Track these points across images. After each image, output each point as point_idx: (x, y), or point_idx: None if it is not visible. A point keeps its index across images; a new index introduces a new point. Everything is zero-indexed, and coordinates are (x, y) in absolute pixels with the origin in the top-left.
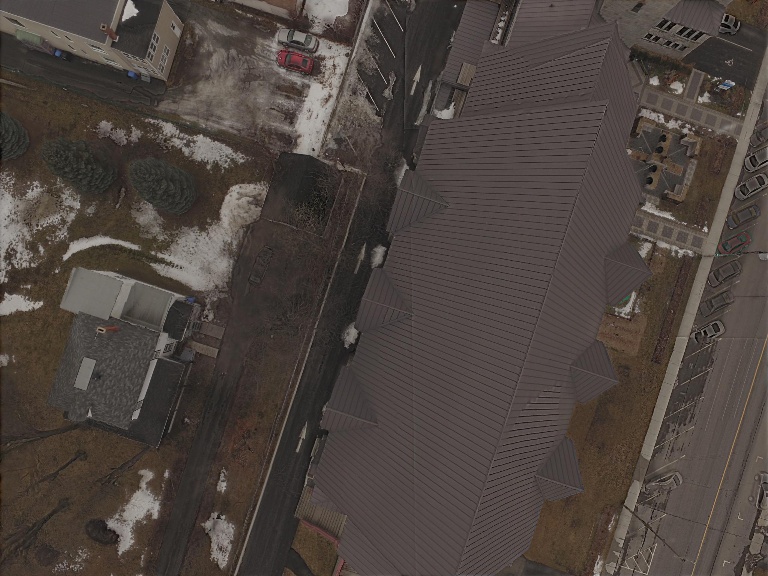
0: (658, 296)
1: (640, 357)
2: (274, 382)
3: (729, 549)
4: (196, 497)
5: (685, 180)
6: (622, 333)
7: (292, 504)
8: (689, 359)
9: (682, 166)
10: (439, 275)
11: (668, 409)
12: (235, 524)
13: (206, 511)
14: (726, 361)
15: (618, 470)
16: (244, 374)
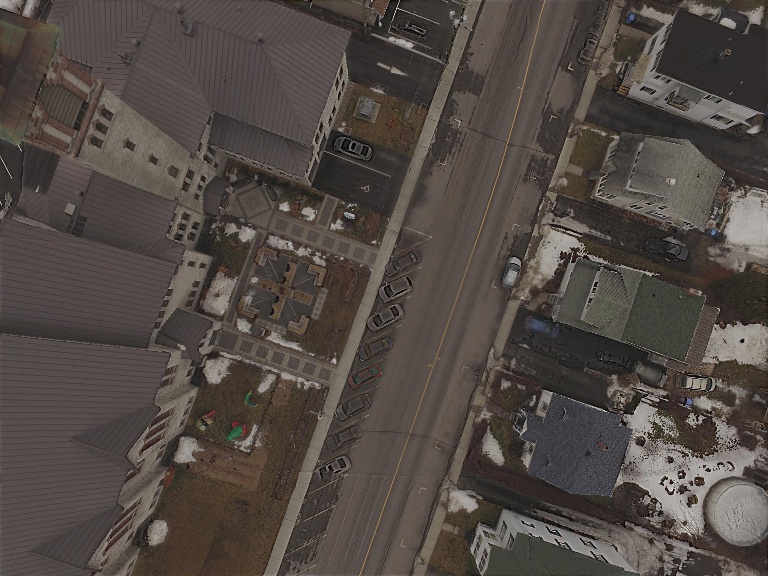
0: (281, 429)
1: (260, 492)
2: None
3: None
4: None
5: (314, 310)
6: (240, 467)
7: None
8: (313, 495)
9: (312, 295)
10: None
11: (289, 546)
12: None
13: None
14: (351, 498)
15: None
16: None
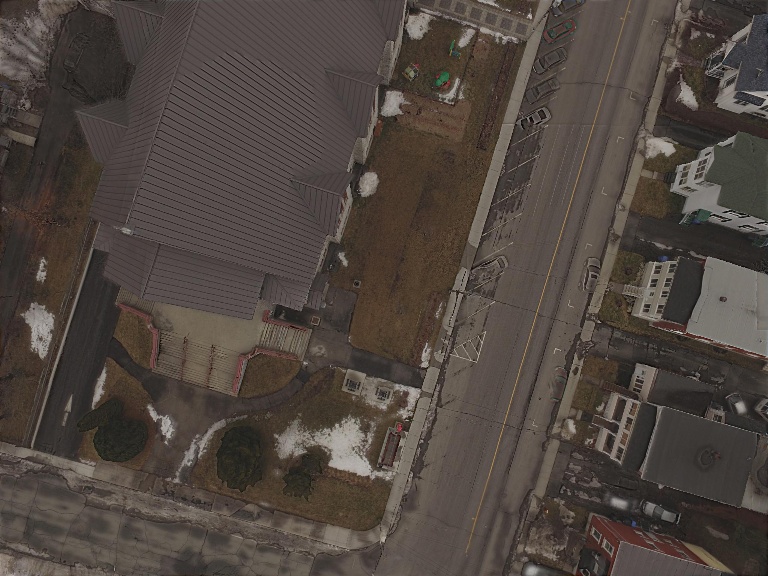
0: (482, 83)
1: (465, 143)
2: (94, 171)
3: (560, 336)
4: (15, 287)
5: None
6: (446, 119)
7: (113, 293)
8: (516, 146)
9: None
10: None
11: (495, 196)
12: (55, 314)
13: (26, 301)
14: (553, 148)
15: (445, 257)
16: (63, 163)
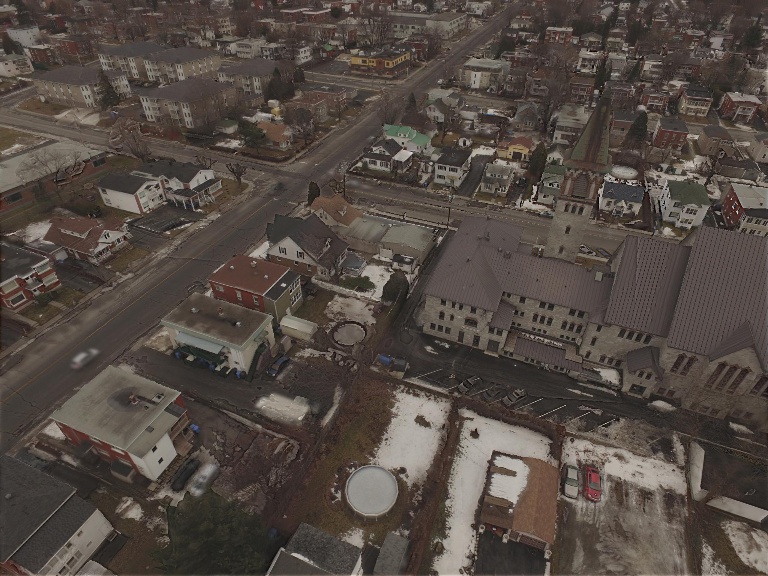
0: None
1: None
2: None
3: None
4: None
5: None
6: None
7: None
8: None
9: None
10: None
11: None
12: None
13: None
14: None
15: None
16: None
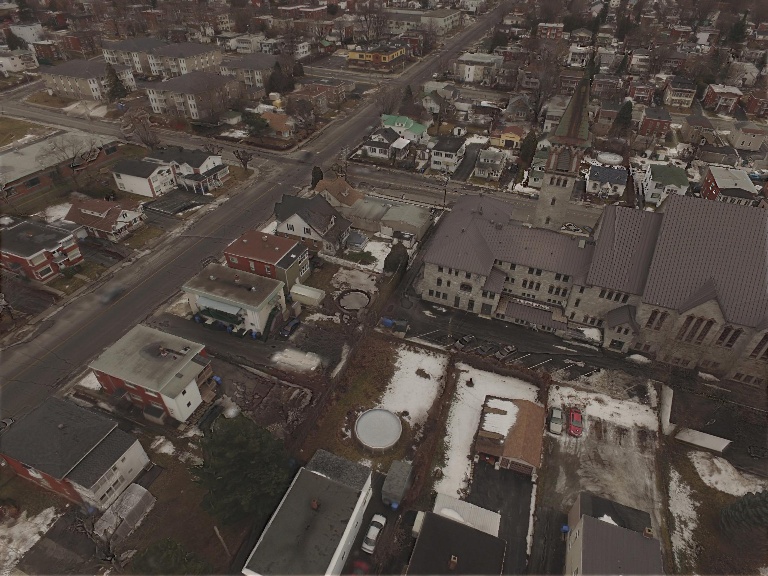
0: None
1: None
2: None
3: None
4: None
5: None
6: None
7: None
8: None
9: None
10: (762, 277)
11: None
12: None
13: None
14: None
15: None
16: None
